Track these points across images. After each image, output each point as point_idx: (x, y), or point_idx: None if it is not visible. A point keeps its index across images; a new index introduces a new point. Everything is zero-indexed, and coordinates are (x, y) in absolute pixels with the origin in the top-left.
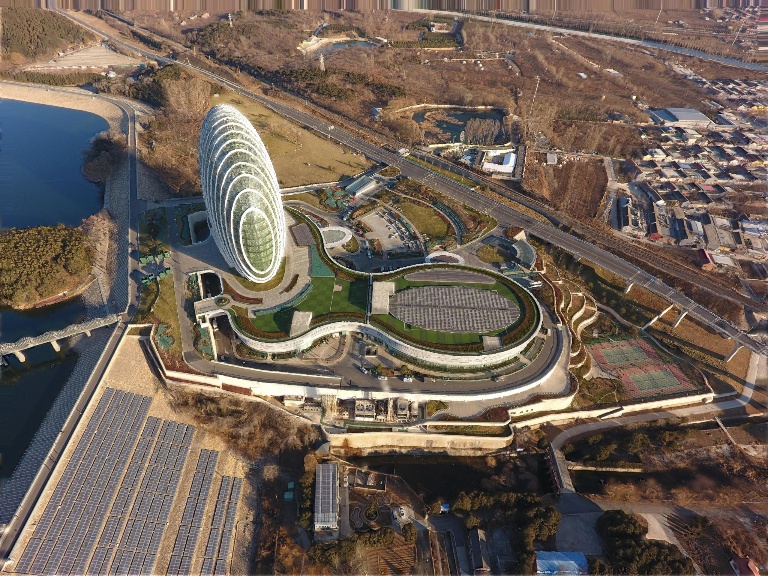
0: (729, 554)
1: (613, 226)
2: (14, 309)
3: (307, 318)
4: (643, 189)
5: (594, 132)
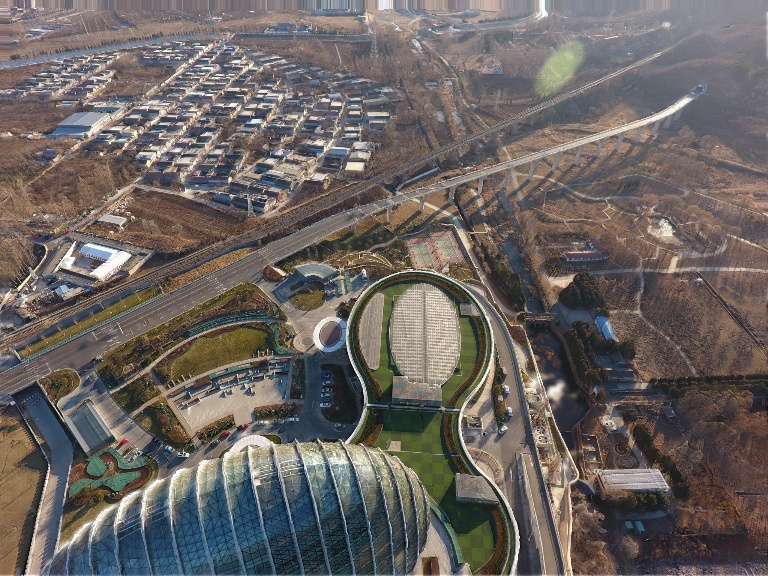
0: (564, 259)
1: None
2: None
3: (467, 479)
4: (201, 182)
5: (100, 172)
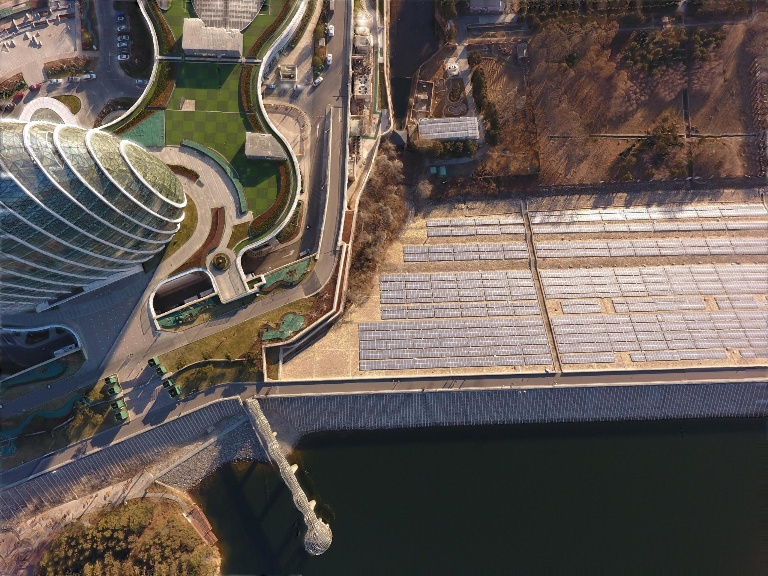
0: None
1: None
2: (220, 571)
3: (257, 138)
4: None
5: None
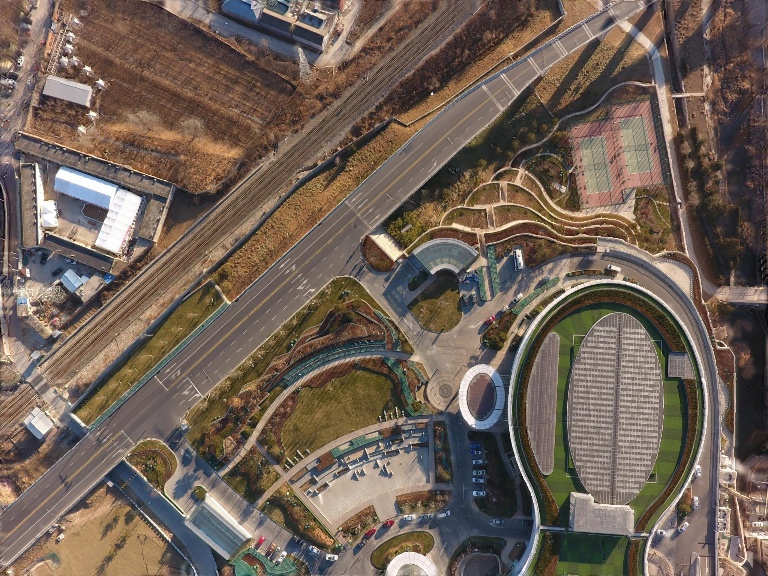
0: None
1: (308, 59)
2: None
3: None
4: None
5: None
